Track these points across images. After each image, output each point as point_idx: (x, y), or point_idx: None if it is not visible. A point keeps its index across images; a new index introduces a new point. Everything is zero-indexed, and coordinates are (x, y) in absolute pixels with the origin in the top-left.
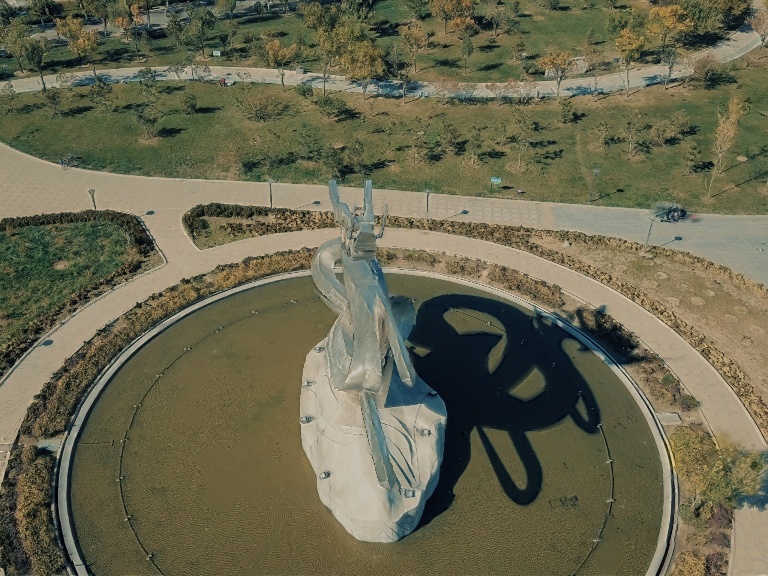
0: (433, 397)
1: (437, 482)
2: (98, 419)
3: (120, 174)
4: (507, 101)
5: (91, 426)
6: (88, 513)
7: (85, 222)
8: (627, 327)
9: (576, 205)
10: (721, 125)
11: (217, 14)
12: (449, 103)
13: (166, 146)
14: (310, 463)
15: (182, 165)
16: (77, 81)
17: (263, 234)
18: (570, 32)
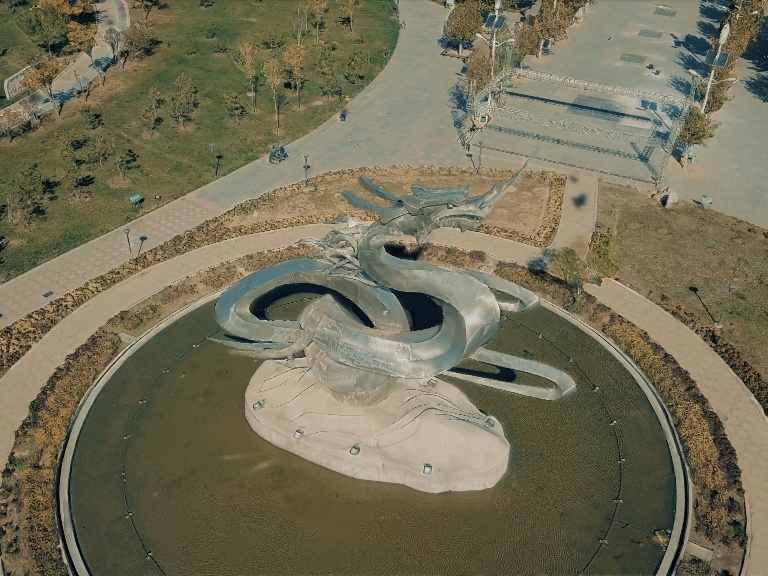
0: None
1: None
2: None
3: None
4: (12, 135)
5: None
6: None
7: None
8: None
9: (211, 184)
10: (264, 66)
11: None
12: None
13: None
14: (383, 482)
15: None
16: None
17: None
18: None
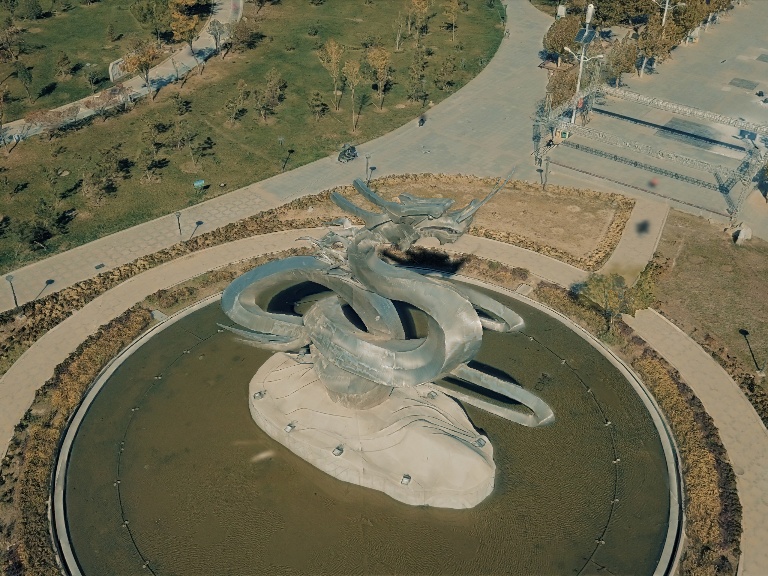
0: None
1: None
2: None
3: None
4: (107, 115)
5: None
6: None
7: None
8: (426, 246)
9: (276, 177)
10: (345, 65)
11: None
12: (54, 136)
13: None
14: (363, 487)
15: None
16: None
17: (36, 339)
18: (81, 35)
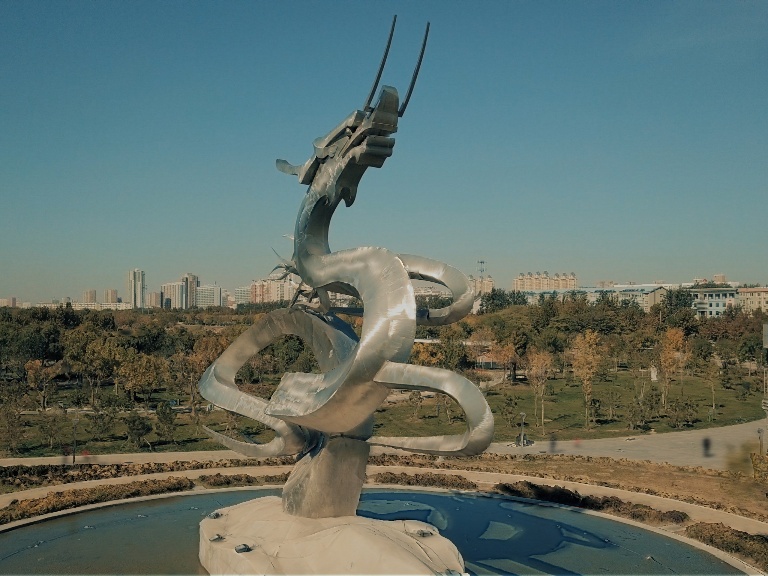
0: None
1: None
2: None
3: None
4: None
5: None
6: None
7: None
8: None
9: None
10: None
11: None
12: None
13: None
14: None
15: None
16: None
17: (68, 483)
18: None
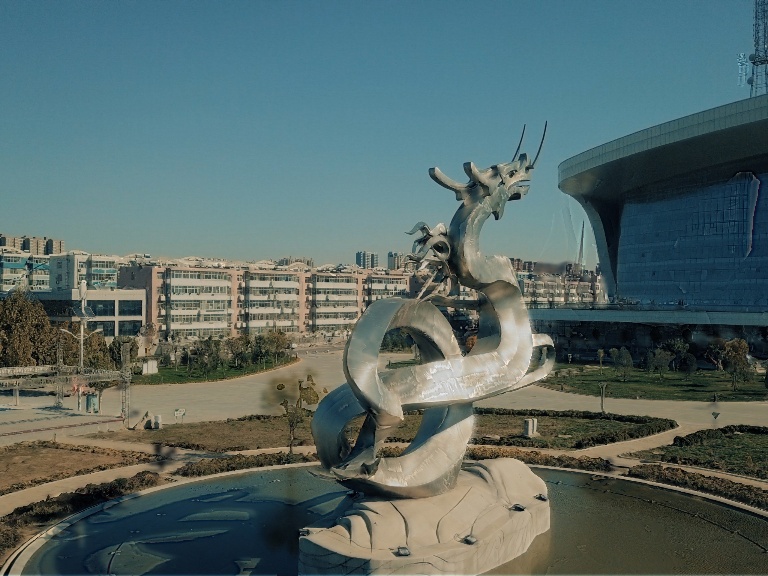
0: None
1: None
2: None
3: None
4: None
5: None
6: None
7: None
8: None
9: None
10: None
11: None
12: None
13: None
14: None
15: None
16: None
17: None
18: None
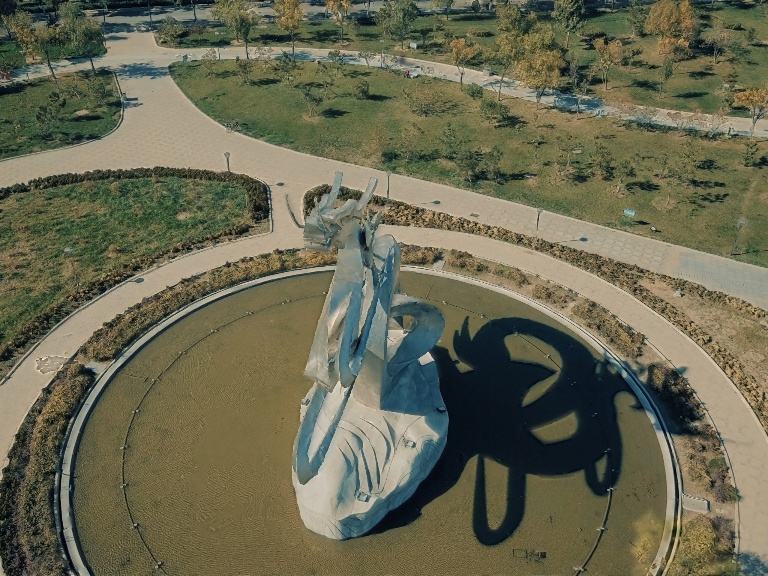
0: (440, 413)
1: (409, 496)
2: (145, 356)
3: (272, 144)
4: (691, 133)
5: (137, 360)
6: (96, 433)
7: (220, 182)
8: (700, 396)
9: (712, 255)
10: None
11: (437, 8)
12: (625, 126)
13: (324, 125)
14: None
15: (330, 145)
16: (280, 55)
17: None
18: None
